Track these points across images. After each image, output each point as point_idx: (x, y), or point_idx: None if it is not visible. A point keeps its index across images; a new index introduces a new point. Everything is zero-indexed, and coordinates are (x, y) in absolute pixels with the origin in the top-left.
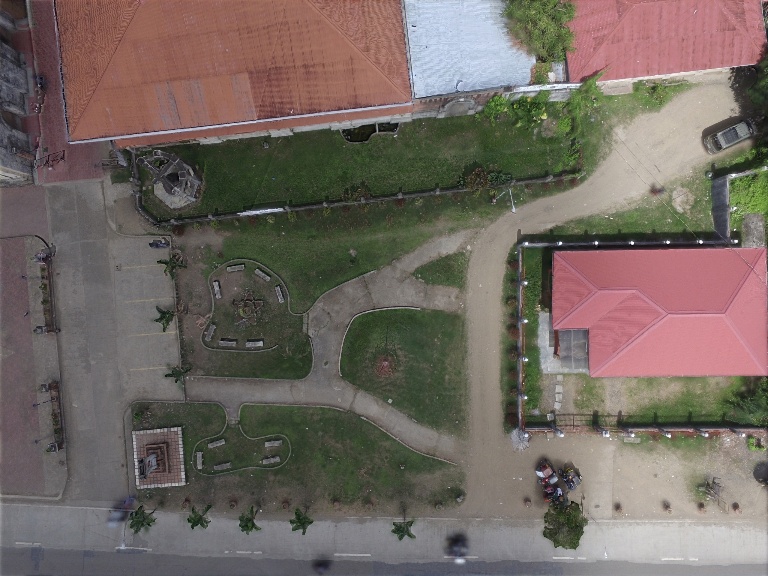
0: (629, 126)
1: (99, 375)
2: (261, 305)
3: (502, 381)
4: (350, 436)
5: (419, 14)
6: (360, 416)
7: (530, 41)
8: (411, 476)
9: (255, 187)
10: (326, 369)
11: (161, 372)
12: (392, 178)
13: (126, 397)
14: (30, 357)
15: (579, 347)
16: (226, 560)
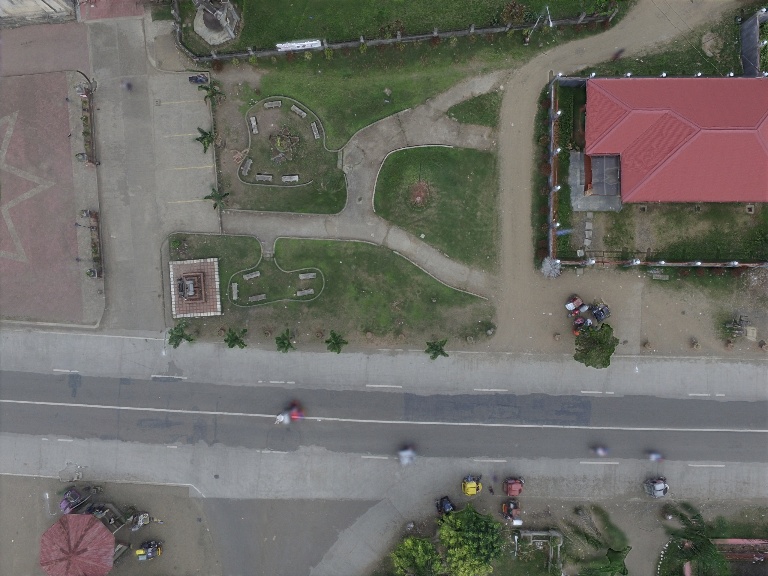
0: None
1: (137, 207)
2: (297, 141)
3: (533, 218)
4: (383, 270)
5: None
6: (393, 251)
7: None
8: (442, 310)
9: (293, 26)
10: (360, 205)
11: (198, 205)
12: (427, 18)
13: (163, 229)
14: (70, 188)
15: (611, 174)
16: (260, 389)
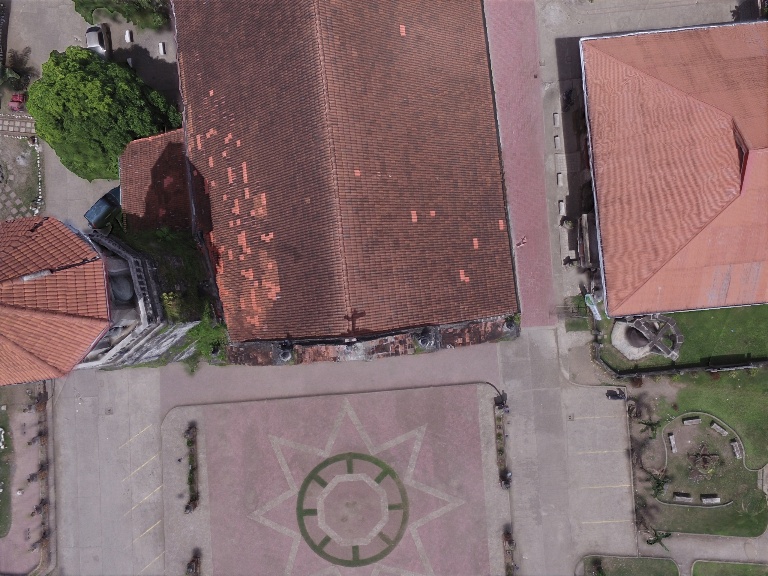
0: None
1: (550, 527)
2: (716, 460)
3: None
4: None
5: None
6: None
7: None
8: None
9: (713, 339)
10: None
11: (614, 526)
12: None
13: (577, 550)
14: (482, 507)
15: None
16: None
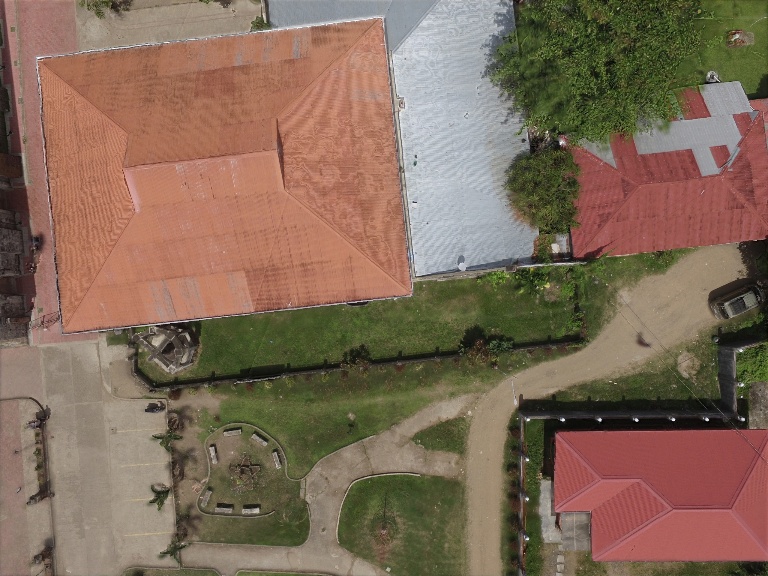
0: (634, 289)
1: (93, 540)
2: (258, 470)
3: (503, 550)
4: None
5: (420, 190)
6: None
7: (533, 219)
8: None
9: (252, 350)
10: (323, 535)
11: (156, 538)
12: (392, 342)
13: (120, 563)
14: (24, 522)
15: (581, 528)
16: None
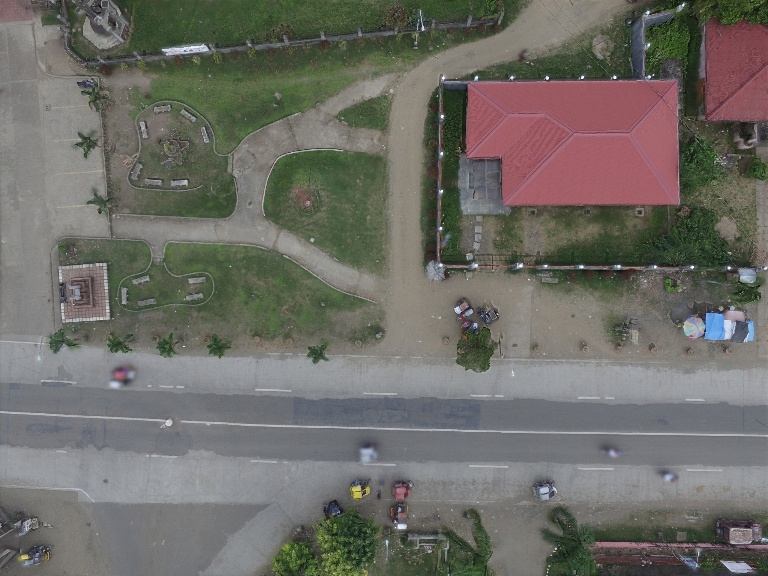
0: None
1: (27, 212)
2: (187, 145)
3: (422, 221)
4: (272, 274)
5: None
6: (282, 255)
7: None
8: (332, 314)
9: (182, 30)
10: (250, 209)
11: (88, 210)
12: (317, 22)
13: (53, 234)
14: None
15: (493, 177)
16: (149, 394)
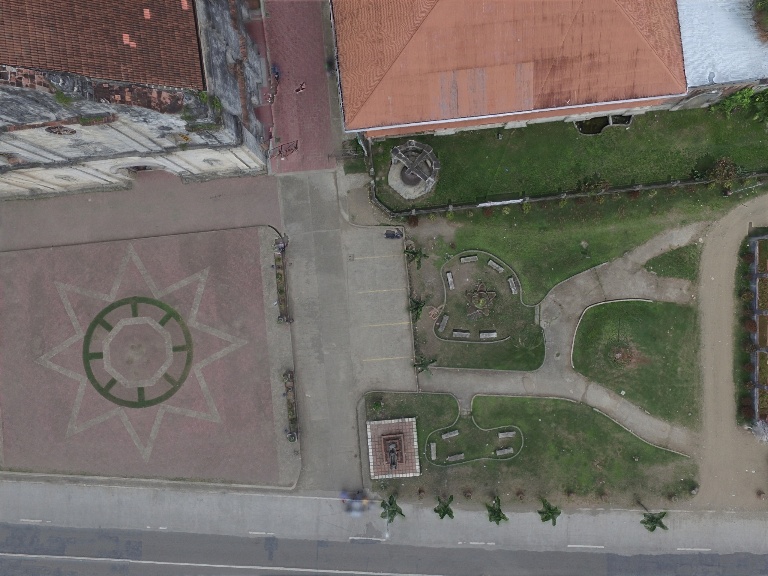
0: None
1: (332, 365)
2: (494, 296)
3: (735, 374)
4: (583, 428)
5: None
6: (593, 408)
7: None
8: (644, 468)
9: (488, 178)
10: (558, 361)
11: (394, 363)
12: (624, 170)
13: (359, 387)
14: (264, 347)
15: None
16: (460, 551)
